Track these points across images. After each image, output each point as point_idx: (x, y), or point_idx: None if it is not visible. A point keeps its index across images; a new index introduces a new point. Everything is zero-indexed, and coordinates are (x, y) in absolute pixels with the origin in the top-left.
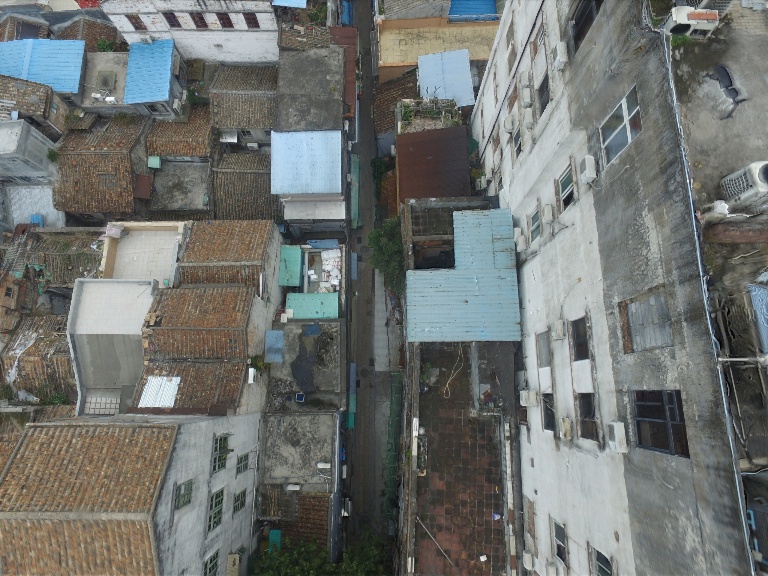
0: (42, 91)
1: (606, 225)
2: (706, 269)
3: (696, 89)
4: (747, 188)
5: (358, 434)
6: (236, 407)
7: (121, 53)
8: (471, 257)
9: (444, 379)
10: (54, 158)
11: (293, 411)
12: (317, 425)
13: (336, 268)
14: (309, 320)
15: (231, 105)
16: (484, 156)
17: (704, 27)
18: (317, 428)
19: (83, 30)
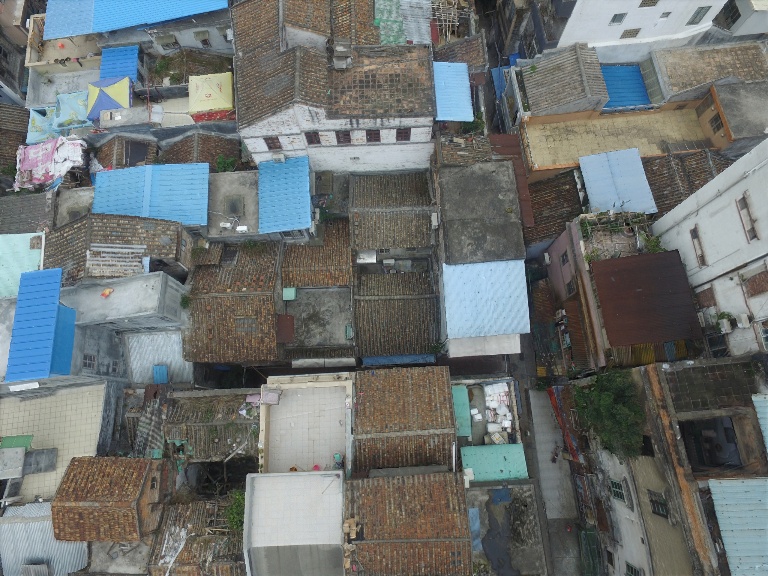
0: (172, 229)
1: None
2: None
3: None
4: None
5: None
6: None
7: (246, 172)
8: None
9: None
10: (187, 305)
11: None
12: None
13: (505, 406)
14: (495, 483)
15: (374, 224)
16: (708, 287)
17: None
18: None
19: (198, 146)
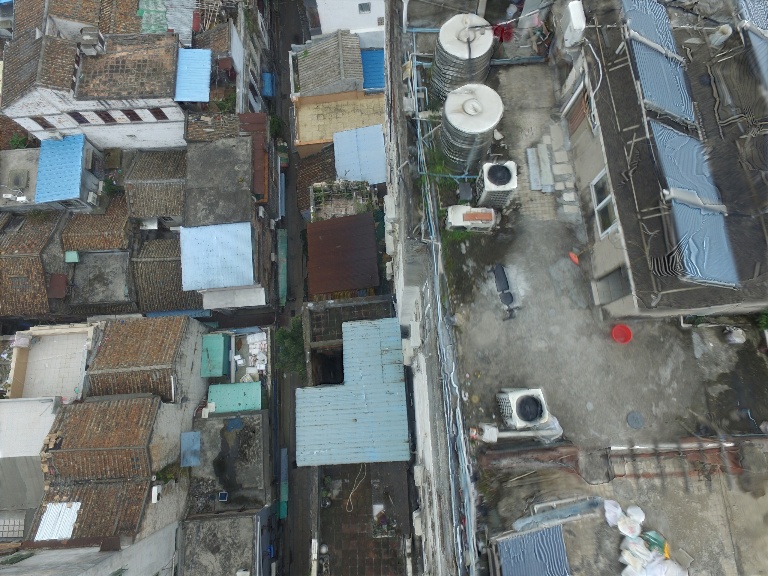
0: None
1: (429, 399)
2: (480, 496)
3: (480, 286)
4: (508, 418)
5: (296, 518)
6: (135, 534)
7: (34, 149)
8: (360, 371)
9: (347, 491)
10: None
11: (213, 515)
12: (237, 529)
13: (262, 352)
14: (231, 414)
15: (147, 195)
16: None
17: (481, 225)
18: (237, 532)
19: None
